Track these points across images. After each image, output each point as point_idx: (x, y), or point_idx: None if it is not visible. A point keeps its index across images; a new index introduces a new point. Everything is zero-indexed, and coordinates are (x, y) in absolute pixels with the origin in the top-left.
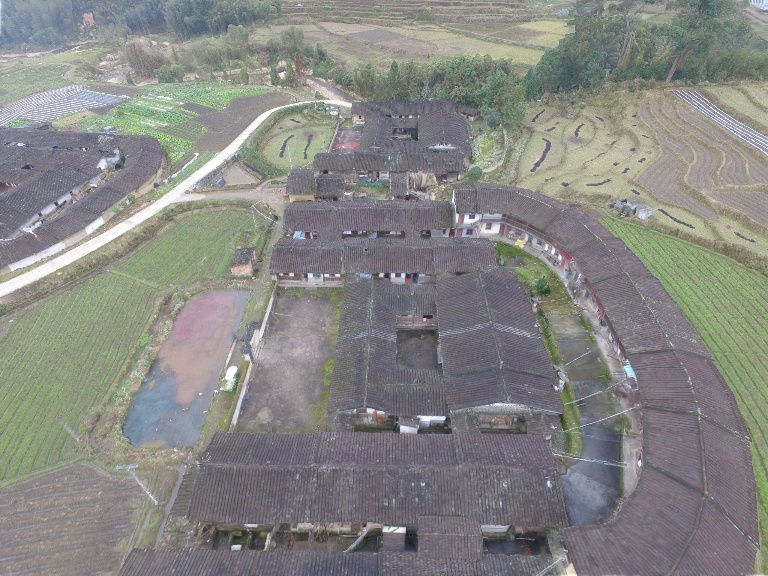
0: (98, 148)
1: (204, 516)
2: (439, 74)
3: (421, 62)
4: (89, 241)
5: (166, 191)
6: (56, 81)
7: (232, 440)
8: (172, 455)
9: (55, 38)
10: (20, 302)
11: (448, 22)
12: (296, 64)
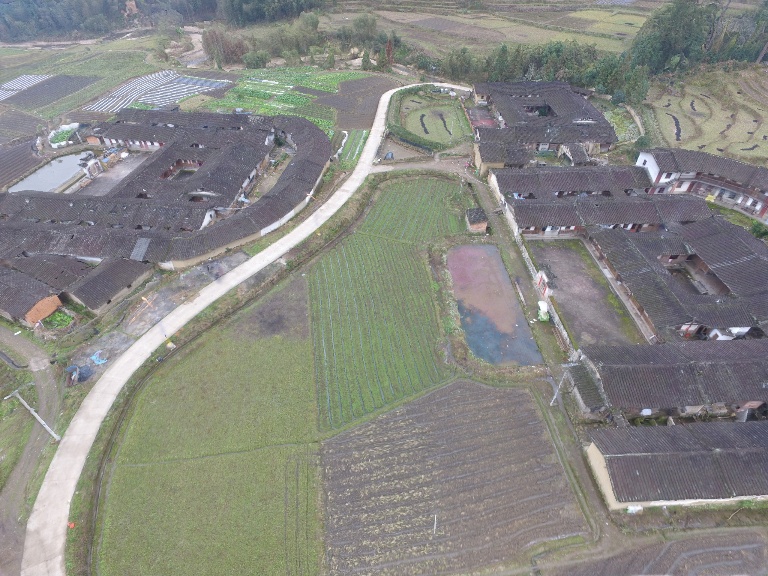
0: (256, 127)
1: (624, 404)
2: (535, 58)
3: None
4: (322, 207)
5: (355, 163)
6: (143, 67)
7: (602, 350)
8: (534, 370)
9: (105, 25)
10: (300, 259)
11: (500, 11)
12: (387, 49)
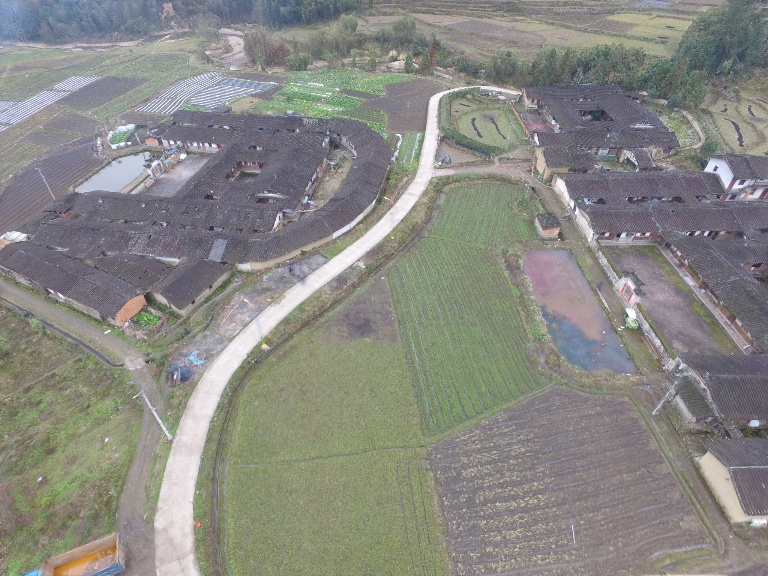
0: (311, 129)
1: (735, 415)
2: (582, 62)
3: (538, 51)
4: (391, 210)
5: (417, 167)
6: (187, 69)
7: (704, 360)
8: (630, 378)
9: (144, 27)
10: (378, 262)
11: (536, 14)
12: (431, 52)
